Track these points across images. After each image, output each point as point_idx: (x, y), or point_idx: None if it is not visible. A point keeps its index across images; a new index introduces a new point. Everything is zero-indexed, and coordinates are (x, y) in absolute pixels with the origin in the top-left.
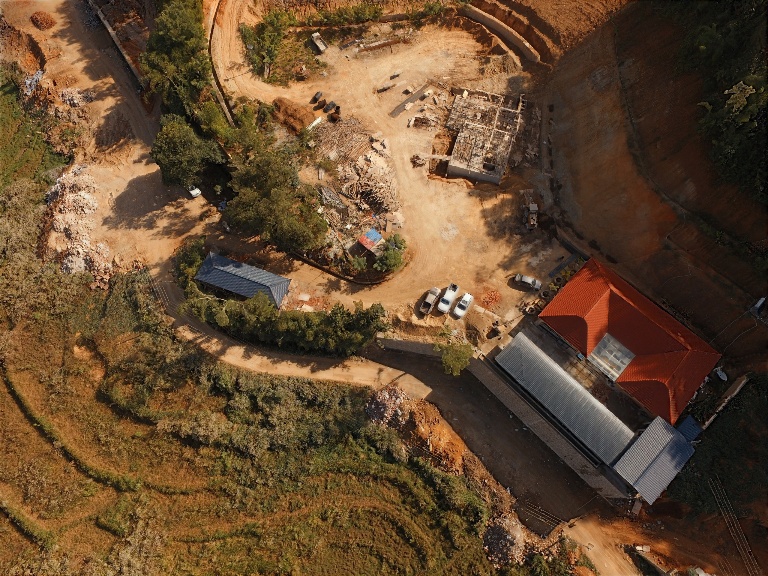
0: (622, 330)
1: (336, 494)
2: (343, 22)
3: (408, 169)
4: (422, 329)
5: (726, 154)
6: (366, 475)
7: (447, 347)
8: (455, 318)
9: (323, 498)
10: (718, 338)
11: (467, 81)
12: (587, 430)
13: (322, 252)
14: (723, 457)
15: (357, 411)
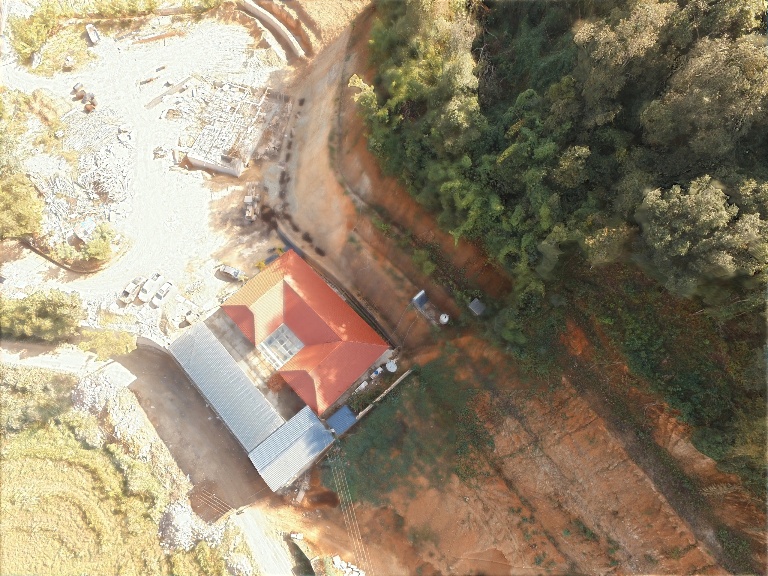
0: (294, 321)
1: (30, 479)
2: (116, 14)
3: (148, 160)
4: (118, 317)
5: (374, 147)
6: (61, 461)
7: (88, 333)
8: (153, 307)
9: (16, 482)
10: (398, 330)
11: (230, 74)
12: (237, 418)
13: (44, 240)
14: (373, 447)
15: (61, 398)
